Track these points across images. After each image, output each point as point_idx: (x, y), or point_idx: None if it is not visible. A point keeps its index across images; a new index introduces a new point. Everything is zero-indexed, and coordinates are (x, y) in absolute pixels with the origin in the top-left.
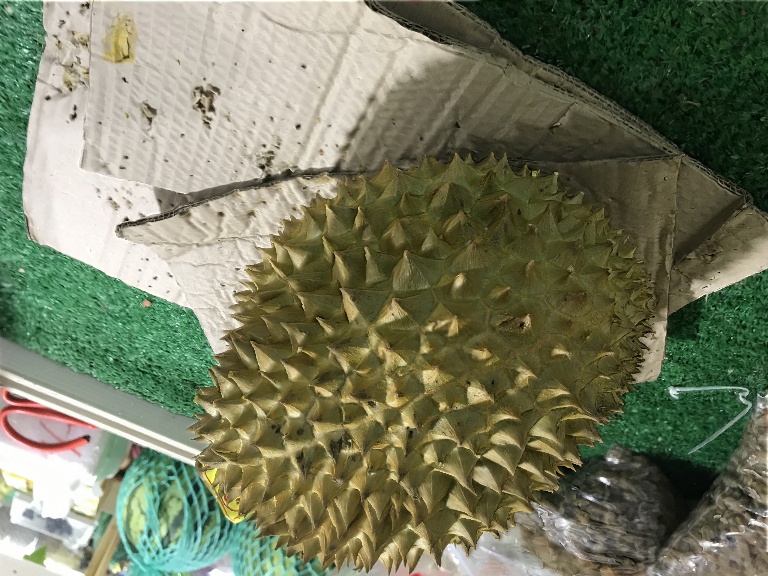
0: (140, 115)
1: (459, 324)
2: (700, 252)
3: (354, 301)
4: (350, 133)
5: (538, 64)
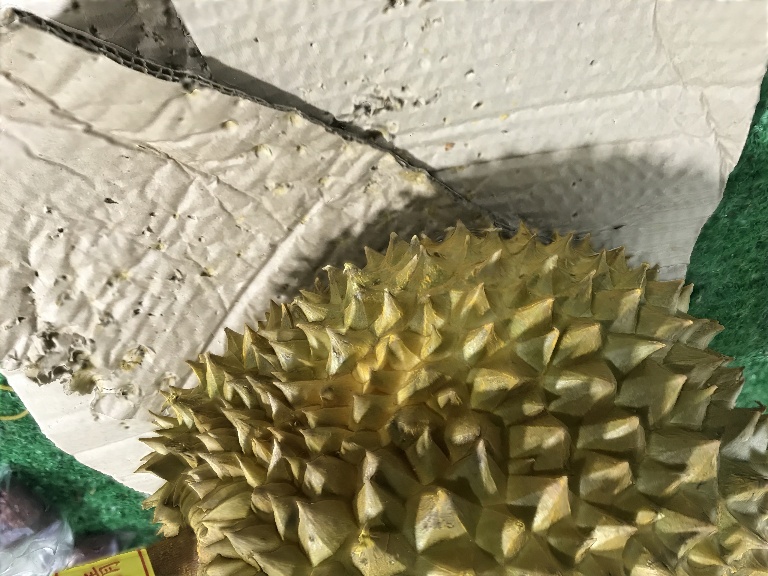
0: None
1: None
2: None
3: (717, 461)
4: (513, 155)
5: None
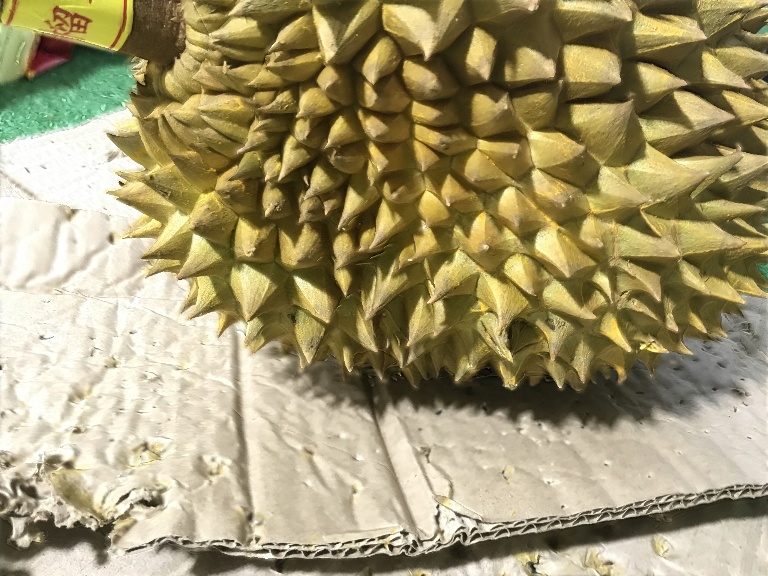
0: (104, 154)
1: None
2: None
3: None
4: None
5: None
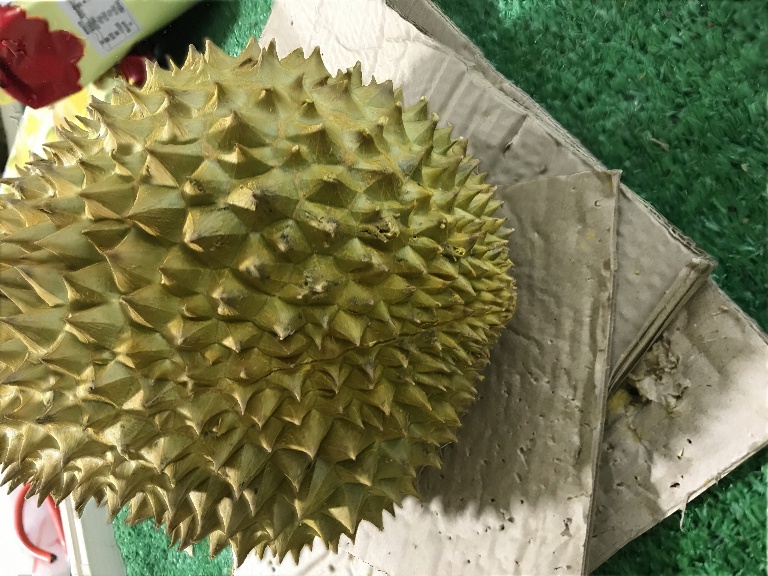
0: None
1: (210, 52)
2: (662, 391)
3: None
4: None
5: (507, 81)
